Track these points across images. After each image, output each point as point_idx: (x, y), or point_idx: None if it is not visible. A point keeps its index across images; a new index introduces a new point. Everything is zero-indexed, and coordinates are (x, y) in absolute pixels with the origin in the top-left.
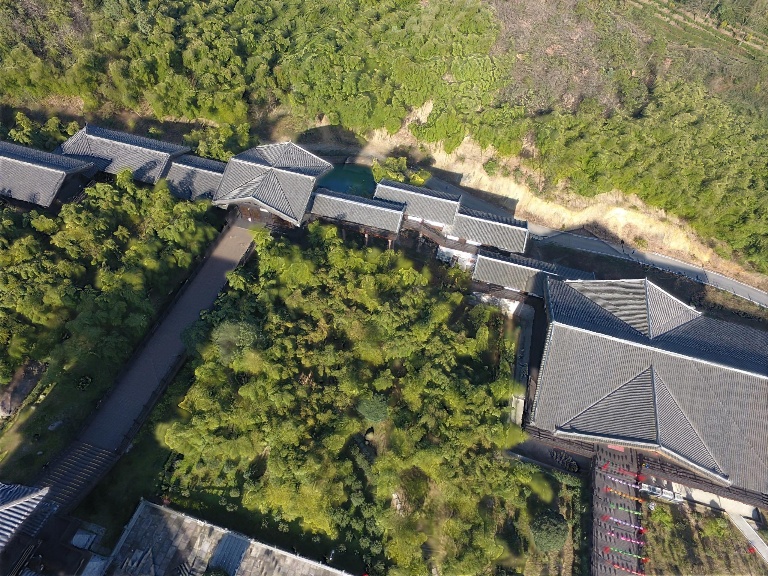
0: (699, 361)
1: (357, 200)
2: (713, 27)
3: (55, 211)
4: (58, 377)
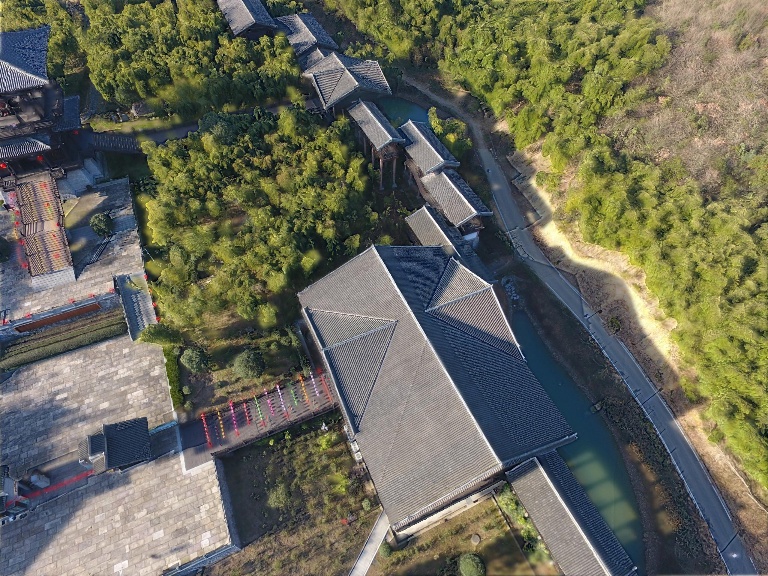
0: (430, 345)
1: (381, 119)
2: None
3: None
4: (155, 105)
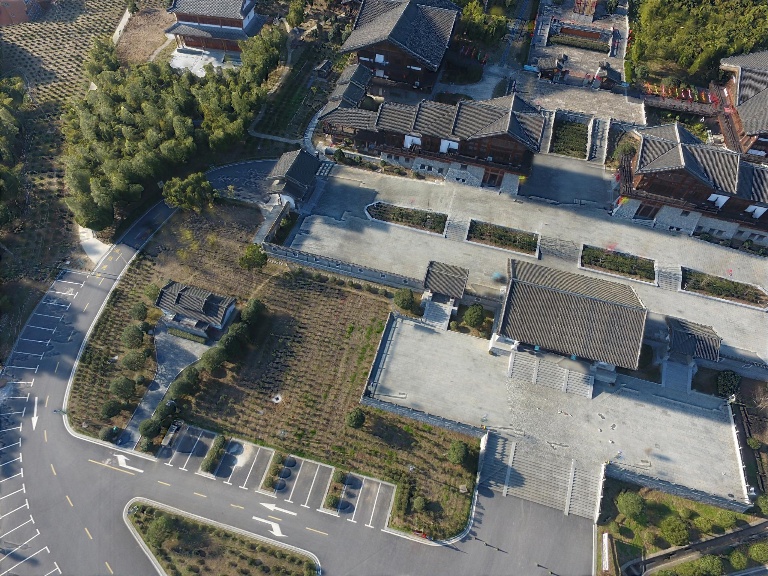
0: None
1: None
2: None
3: None
4: None
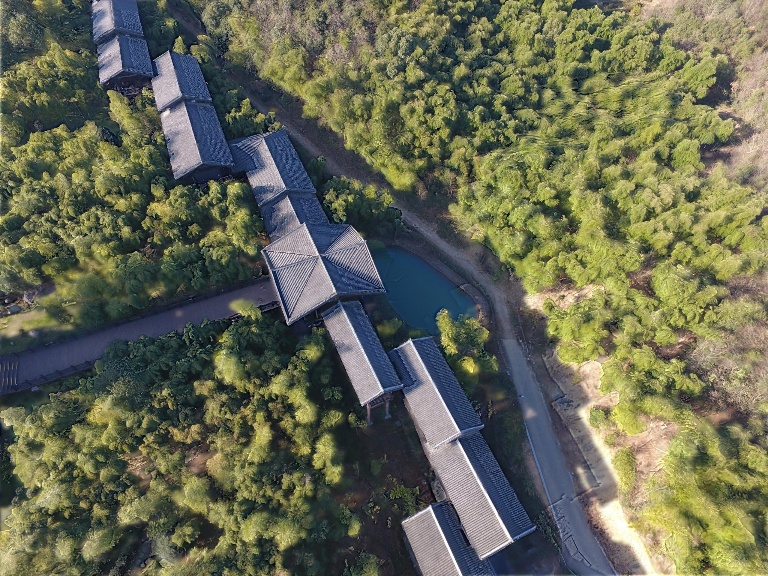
0: None
1: (369, 340)
2: None
3: (185, 184)
4: (49, 305)
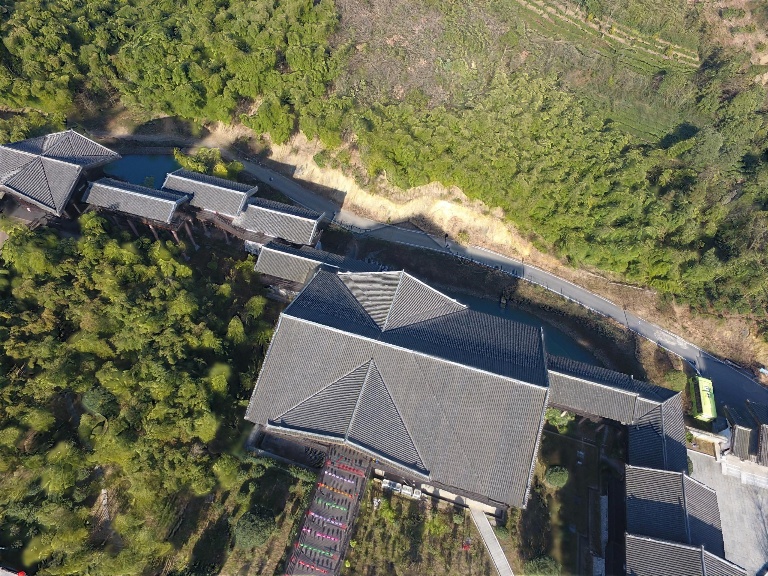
0: (419, 354)
1: (137, 190)
2: (582, 20)
3: None
4: None
